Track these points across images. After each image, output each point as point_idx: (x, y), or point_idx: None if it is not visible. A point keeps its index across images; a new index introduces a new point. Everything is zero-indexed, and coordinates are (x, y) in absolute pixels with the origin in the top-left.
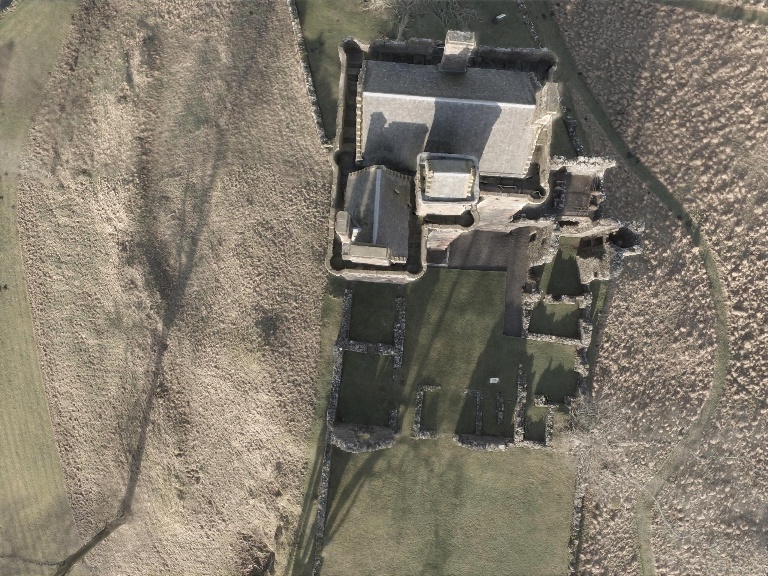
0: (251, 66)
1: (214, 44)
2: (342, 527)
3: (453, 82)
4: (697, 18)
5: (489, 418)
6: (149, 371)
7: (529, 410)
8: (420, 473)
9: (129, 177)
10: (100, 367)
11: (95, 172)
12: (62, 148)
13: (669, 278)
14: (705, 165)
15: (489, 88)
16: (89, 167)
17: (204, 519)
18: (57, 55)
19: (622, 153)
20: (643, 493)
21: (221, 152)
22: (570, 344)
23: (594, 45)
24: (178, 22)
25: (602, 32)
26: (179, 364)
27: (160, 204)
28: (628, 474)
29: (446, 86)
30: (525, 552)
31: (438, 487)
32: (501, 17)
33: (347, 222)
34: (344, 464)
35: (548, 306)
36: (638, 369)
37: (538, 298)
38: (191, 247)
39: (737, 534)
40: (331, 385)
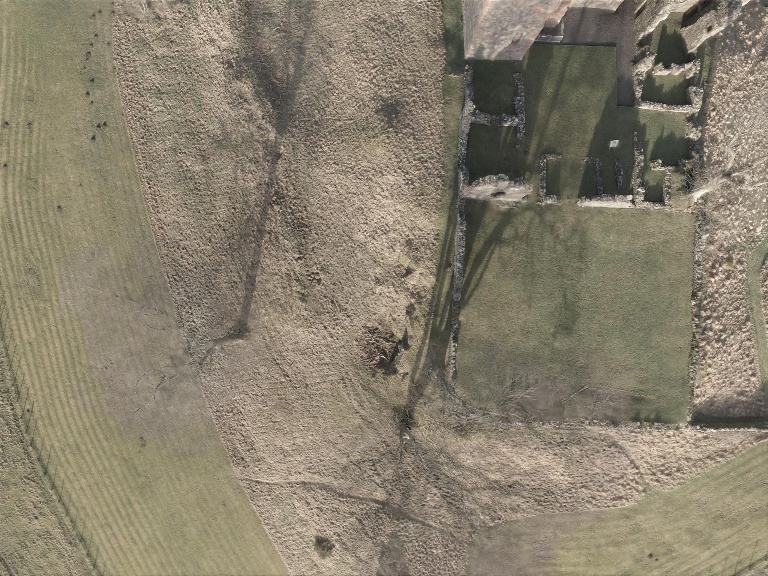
0: None
1: None
2: (477, 291)
3: None
4: None
5: (609, 183)
6: (262, 184)
7: (646, 175)
8: (546, 239)
9: None
10: (207, 192)
11: None
12: None
13: (762, 58)
14: None
15: None
16: None
17: (327, 319)
18: None
19: None
20: (752, 257)
21: None
22: (681, 111)
23: None
24: None
25: None
26: (294, 170)
27: (263, 20)
28: (739, 237)
29: None
30: (650, 308)
31: (564, 252)
32: None
33: None
34: (475, 232)
35: (657, 78)
36: (740, 142)
37: (652, 62)
38: (299, 56)
39: None
40: (458, 158)
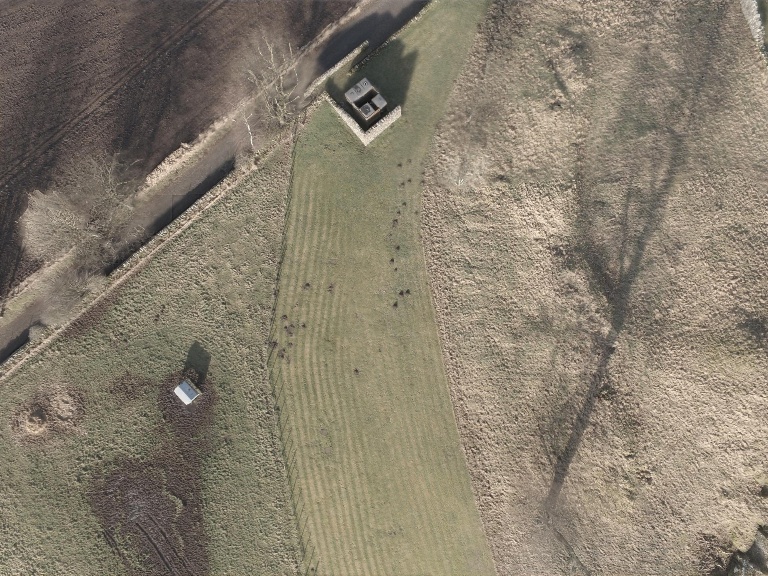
0: (706, 73)
1: (656, 51)
2: None
3: None
4: None
5: None
6: (587, 374)
7: None
8: None
9: (567, 183)
10: (516, 370)
11: (516, 178)
12: (473, 155)
13: None
14: None
15: None
16: (507, 173)
17: (656, 520)
18: (462, 63)
19: None
20: None
21: (680, 157)
22: None
23: None
24: (608, 30)
25: None
26: (628, 367)
27: (595, 209)
28: None
29: None
30: None
31: None
32: None
33: None
34: None
35: None
36: None
37: None
38: (637, 251)
39: None
40: None
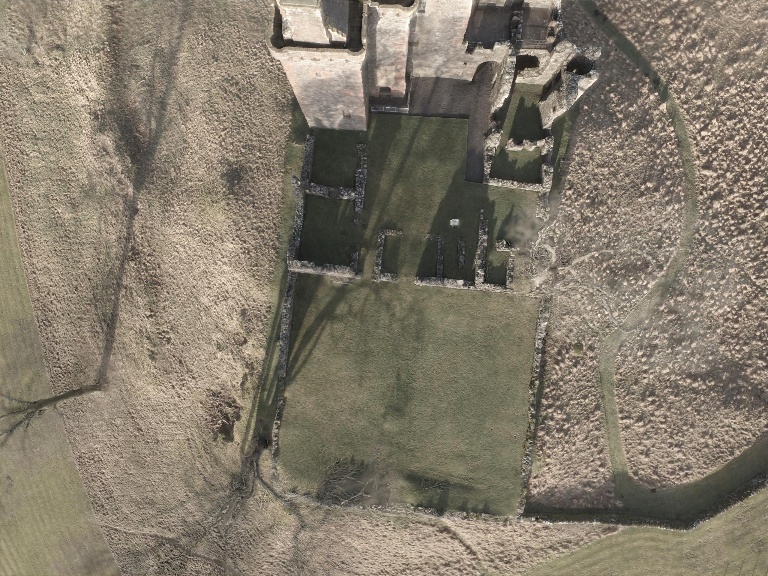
0: None
1: None
2: (304, 368)
3: None
4: None
5: (450, 262)
6: (121, 237)
7: (490, 255)
8: (382, 317)
9: (100, 45)
10: (76, 240)
11: (68, 46)
12: (36, 25)
13: (635, 132)
14: (674, 24)
15: None
16: (62, 42)
17: (175, 378)
18: None
19: (589, 11)
20: (606, 343)
21: (188, 13)
22: (532, 189)
23: None
24: None
25: None
26: (149, 227)
27: (130, 72)
28: (591, 322)
29: None
30: (486, 394)
31: (400, 331)
32: None
33: None
34: (306, 307)
35: (510, 153)
36: (602, 221)
37: (498, 139)
38: (160, 111)
39: (703, 389)
40: (293, 229)
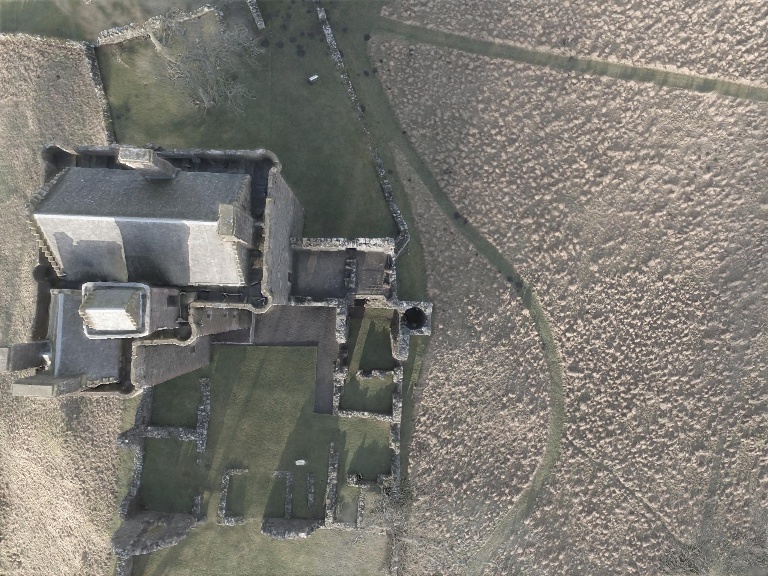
0: (58, 134)
1: (23, 109)
2: None
3: (151, 193)
4: (529, 70)
5: (299, 500)
6: None
7: (341, 490)
8: (229, 559)
9: None
10: None
11: None
12: None
13: (495, 343)
14: (537, 223)
15: (186, 200)
16: None
17: None
18: None
19: (449, 214)
20: None
21: None
22: (383, 420)
23: (419, 102)
24: None
25: (428, 88)
26: None
27: None
28: (450, 549)
29: (138, 200)
30: None
31: (249, 573)
32: (313, 79)
33: (8, 359)
34: (148, 554)
35: (361, 381)
36: (462, 439)
37: (342, 376)
38: (5, 322)
39: None
40: (132, 472)
